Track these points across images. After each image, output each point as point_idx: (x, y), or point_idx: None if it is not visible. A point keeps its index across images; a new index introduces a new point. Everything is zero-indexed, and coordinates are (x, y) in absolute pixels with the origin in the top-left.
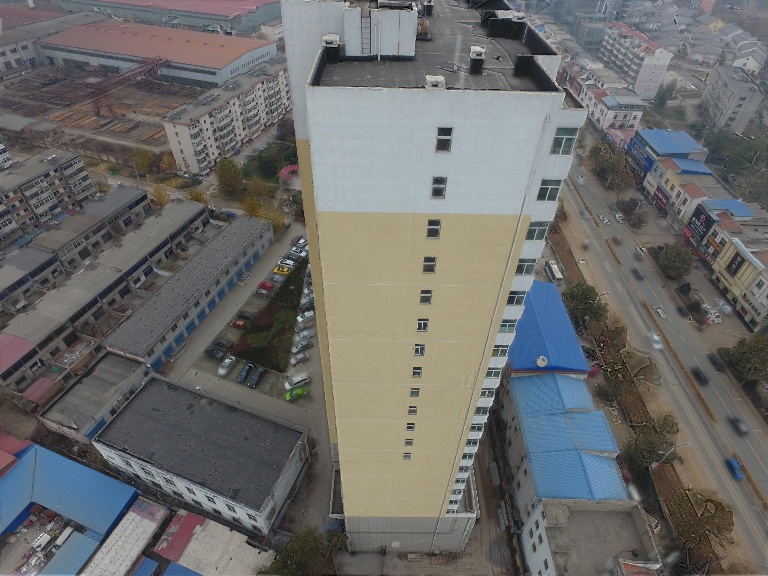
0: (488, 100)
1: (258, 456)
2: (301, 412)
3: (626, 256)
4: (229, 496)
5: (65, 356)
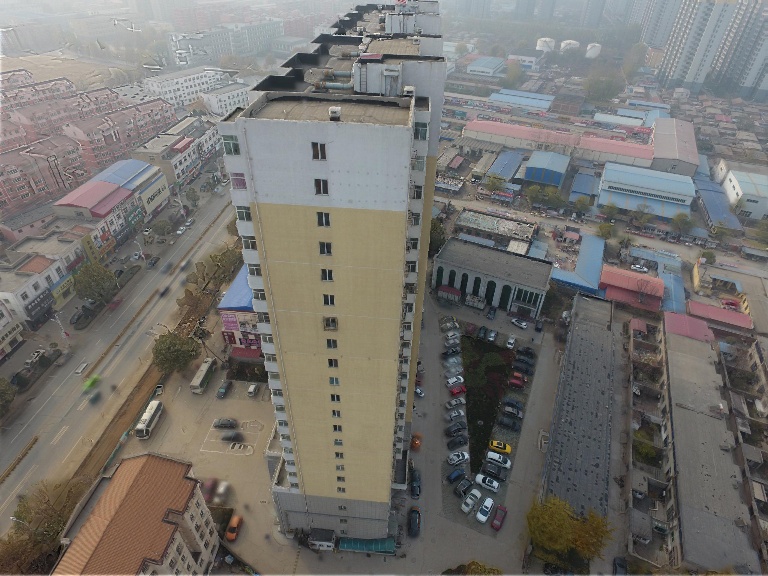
0: (384, 7)
1: (459, 254)
2: (443, 312)
3: (7, 456)
4: (468, 243)
5: (653, 357)
